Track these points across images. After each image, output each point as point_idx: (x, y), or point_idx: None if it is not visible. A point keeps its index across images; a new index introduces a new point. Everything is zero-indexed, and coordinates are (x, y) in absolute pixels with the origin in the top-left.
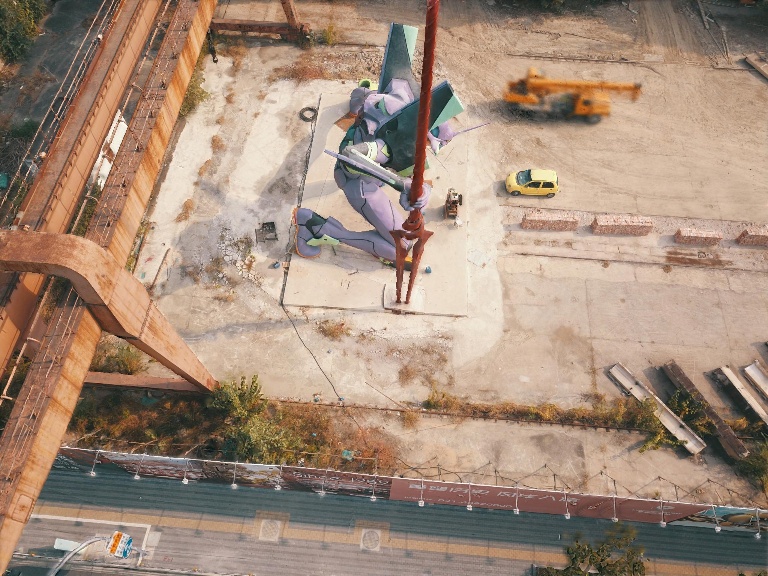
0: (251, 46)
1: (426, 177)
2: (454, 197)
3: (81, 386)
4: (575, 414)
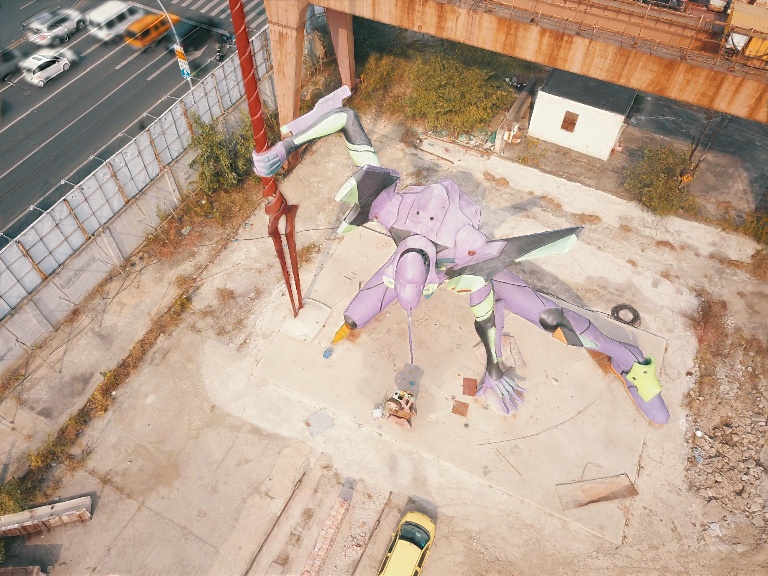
0: None
1: (473, 411)
2: (397, 393)
3: None
4: None
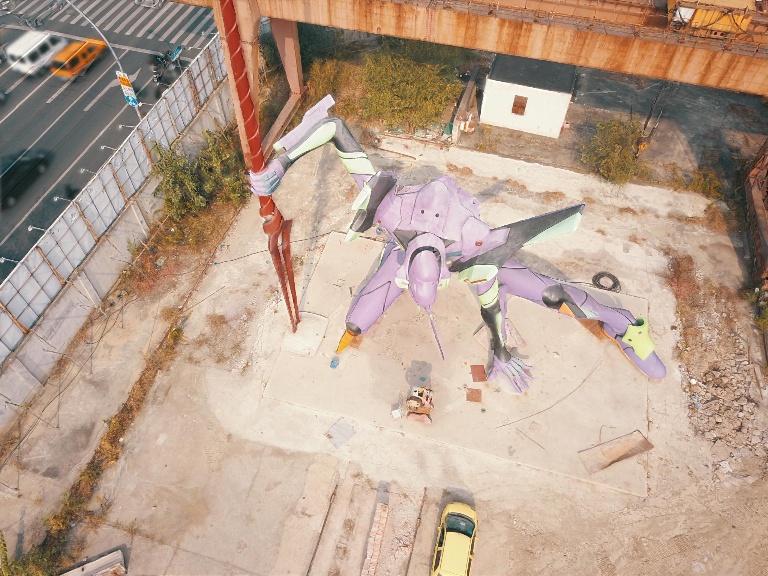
0: (732, 237)
1: (487, 396)
2: (416, 391)
3: (181, 1)
4: (85, 471)
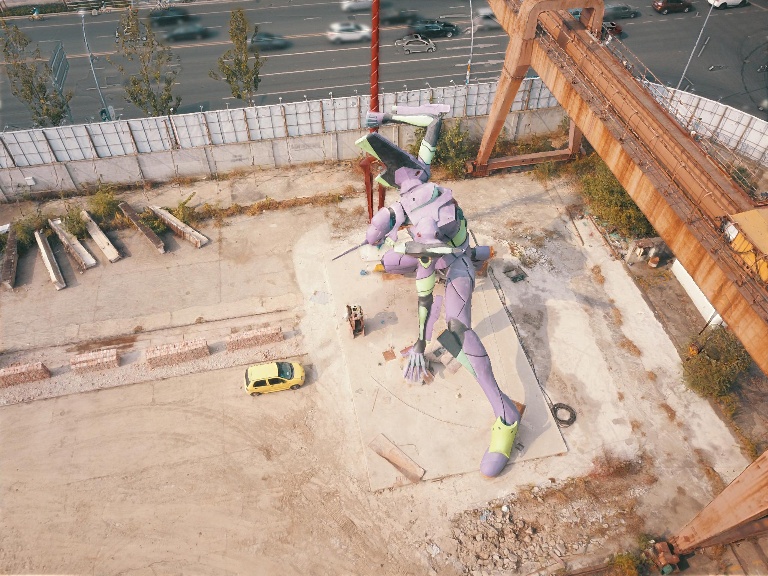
0: None
1: (393, 363)
2: (355, 306)
3: None
4: (237, 204)
